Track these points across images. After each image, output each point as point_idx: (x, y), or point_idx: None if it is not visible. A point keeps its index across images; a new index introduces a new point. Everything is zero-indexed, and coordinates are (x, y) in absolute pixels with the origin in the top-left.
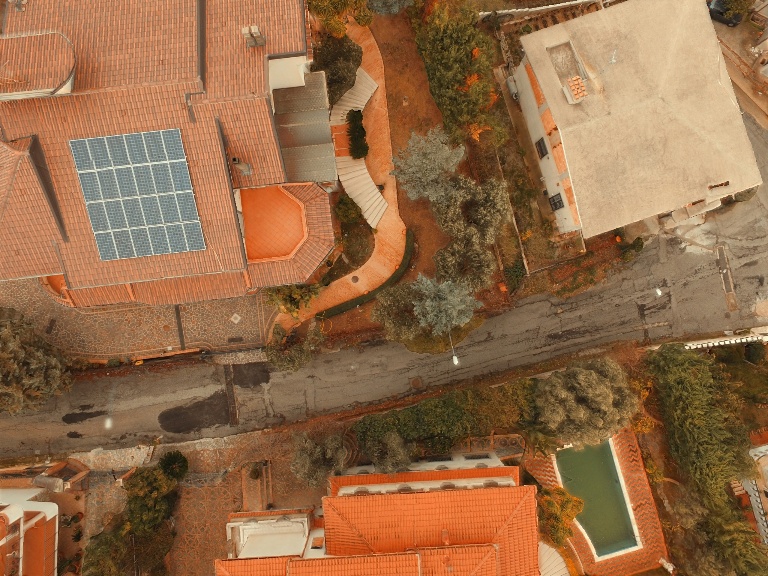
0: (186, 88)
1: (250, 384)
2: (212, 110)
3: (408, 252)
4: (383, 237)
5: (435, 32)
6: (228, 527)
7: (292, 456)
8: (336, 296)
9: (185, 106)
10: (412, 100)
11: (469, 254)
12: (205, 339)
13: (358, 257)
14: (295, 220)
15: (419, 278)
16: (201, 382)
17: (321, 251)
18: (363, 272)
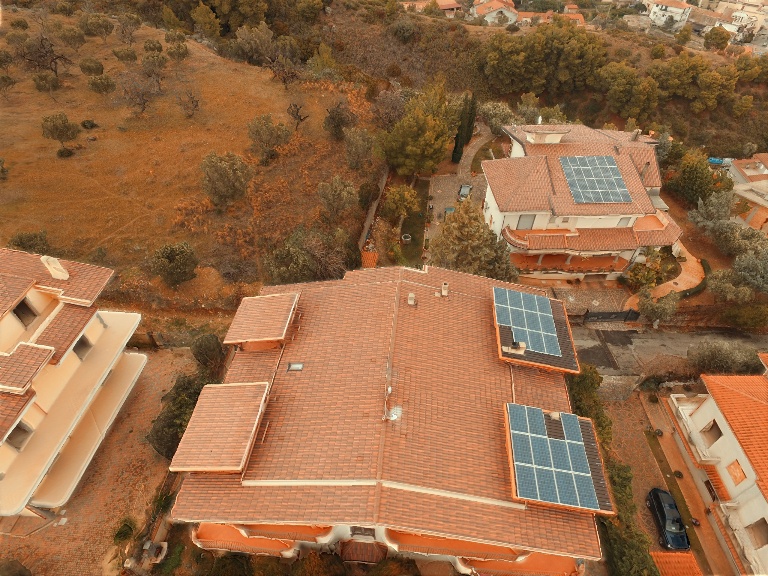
0: (613, 144)
1: (619, 344)
2: (628, 151)
3: (708, 268)
4: (685, 263)
5: (689, 168)
6: (673, 397)
7: (677, 393)
8: (666, 292)
9: (614, 150)
10: (670, 211)
11: (759, 257)
12: (577, 313)
13: (672, 272)
14: (653, 221)
15: (737, 260)
16: (582, 337)
17: (677, 232)
18: (679, 280)
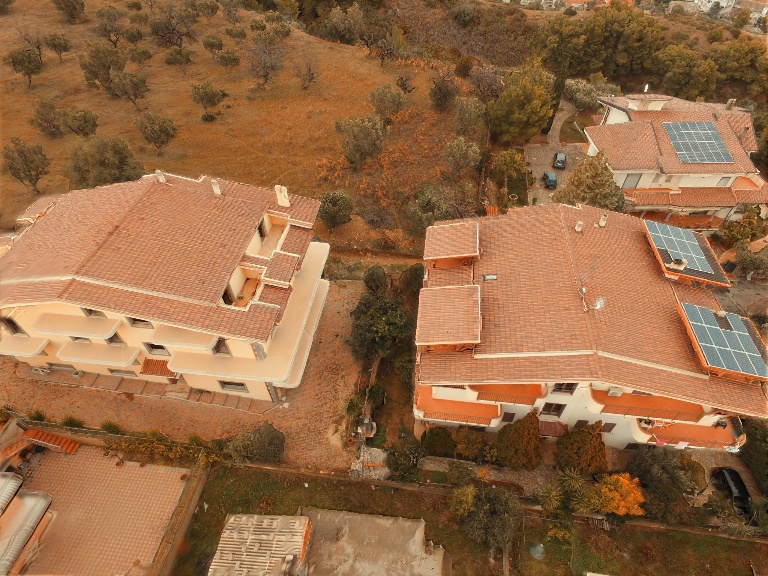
0: None
1: (718, 291)
2: (725, 117)
3: None
4: None
5: None
6: None
7: None
8: (757, 249)
9: (712, 116)
10: None
11: None
12: None
13: (761, 232)
14: None
15: None
16: None
17: None
18: None
